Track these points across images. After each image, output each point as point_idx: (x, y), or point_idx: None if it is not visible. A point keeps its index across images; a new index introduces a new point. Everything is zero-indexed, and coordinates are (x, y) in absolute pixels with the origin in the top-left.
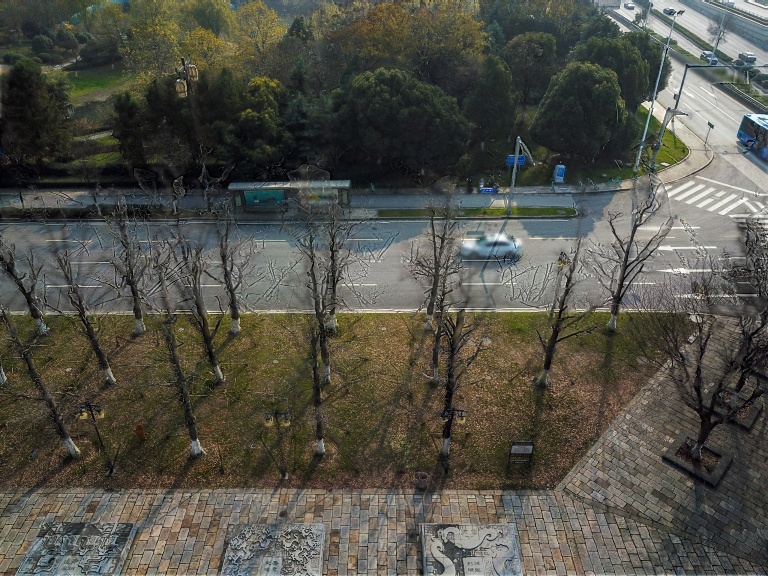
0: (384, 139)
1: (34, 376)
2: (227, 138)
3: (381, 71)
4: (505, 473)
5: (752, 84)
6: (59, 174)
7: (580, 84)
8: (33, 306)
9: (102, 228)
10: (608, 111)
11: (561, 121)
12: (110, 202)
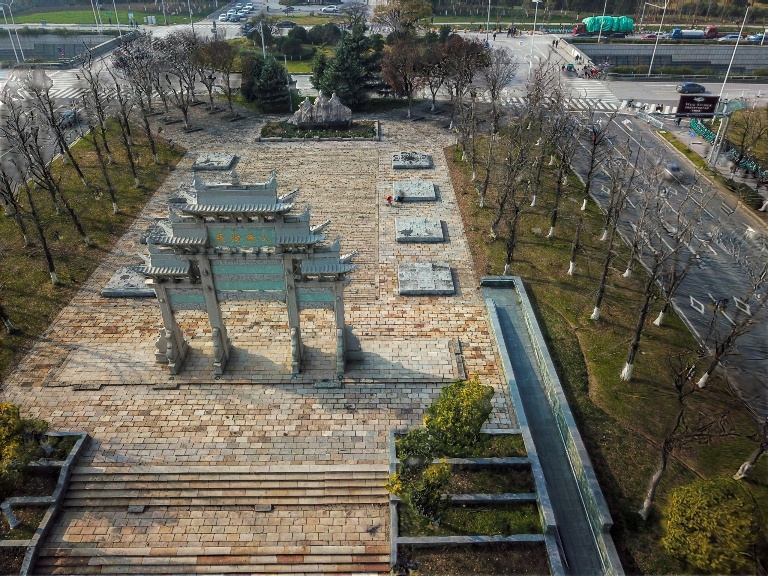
0: None
1: (63, 199)
2: None
3: None
4: (175, 156)
5: None
6: None
7: None
8: None
9: None
10: None
11: None
12: None
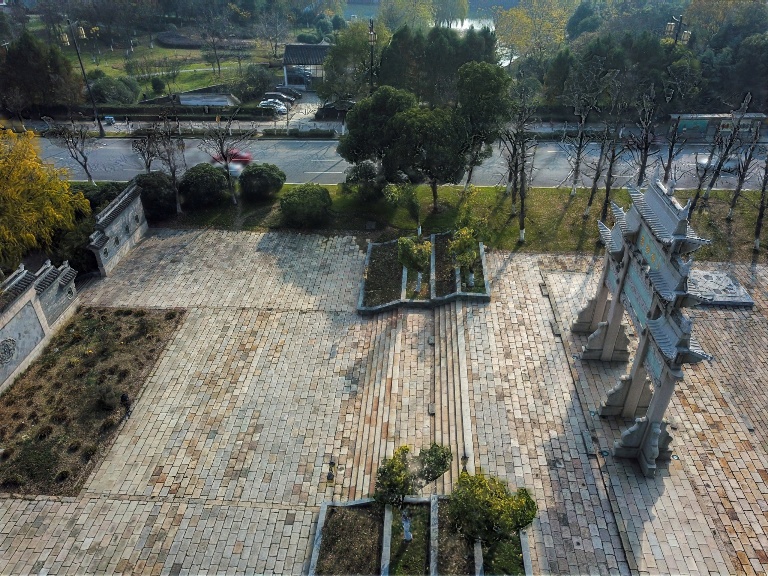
0: None
1: (763, 193)
2: None
3: None
4: None
5: None
6: None
7: None
8: (642, 176)
9: None
10: None
11: None
12: (569, 129)
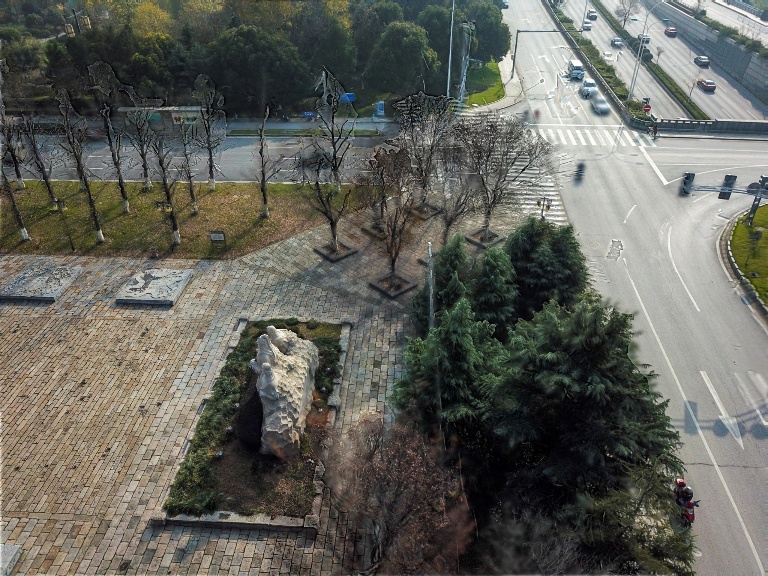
0: (241, 78)
1: None
2: (120, 74)
3: (242, 27)
4: (209, 253)
5: (582, 48)
6: (7, 105)
7: (394, 38)
8: None
9: (26, 138)
10: (416, 59)
11: (379, 66)
12: (36, 122)
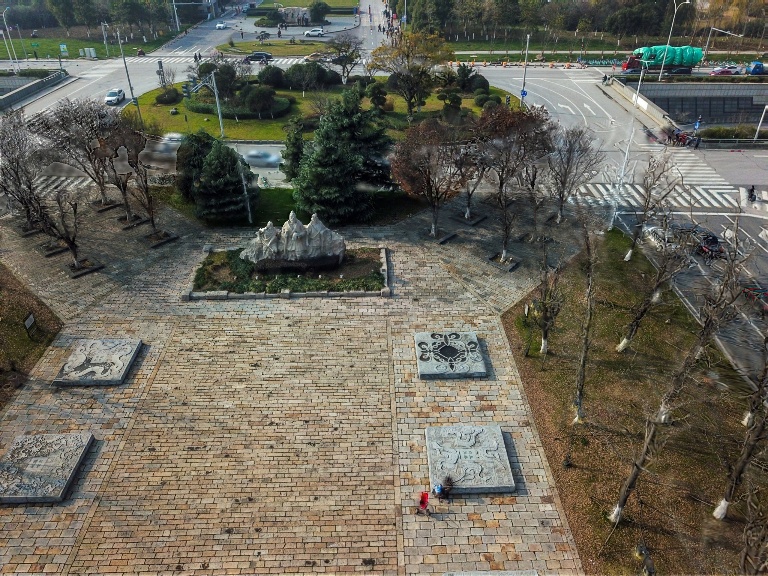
0: None
1: None
2: None
3: None
4: (36, 343)
5: None
6: None
7: None
8: None
9: None
10: None
11: None
12: None
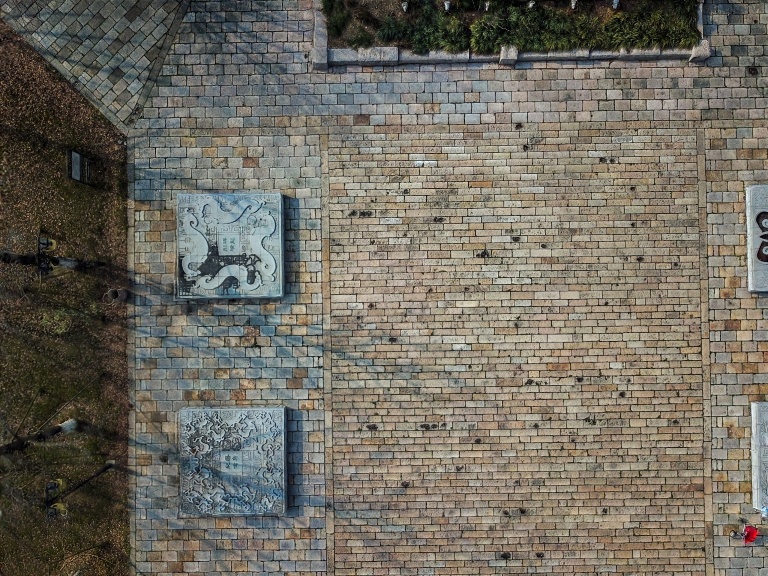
0: None
1: None
2: None
3: None
4: (103, 191)
5: None
6: None
7: None
8: None
9: None
10: None
11: None
12: None
